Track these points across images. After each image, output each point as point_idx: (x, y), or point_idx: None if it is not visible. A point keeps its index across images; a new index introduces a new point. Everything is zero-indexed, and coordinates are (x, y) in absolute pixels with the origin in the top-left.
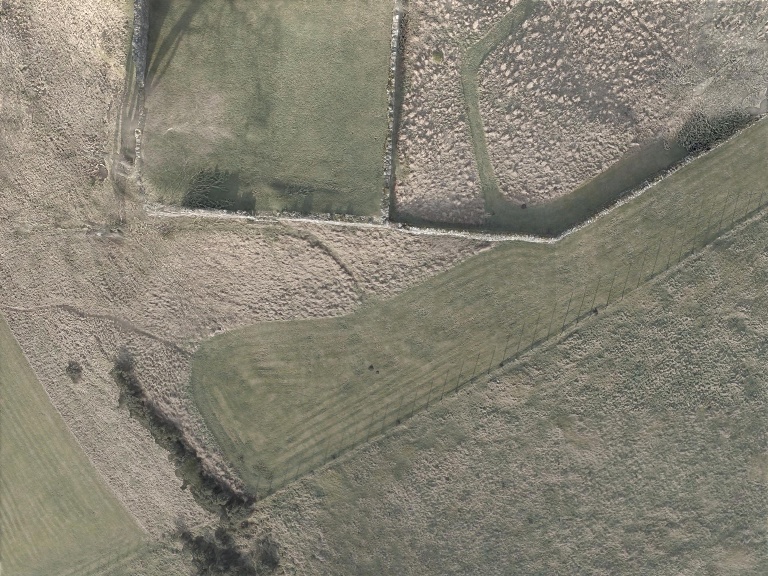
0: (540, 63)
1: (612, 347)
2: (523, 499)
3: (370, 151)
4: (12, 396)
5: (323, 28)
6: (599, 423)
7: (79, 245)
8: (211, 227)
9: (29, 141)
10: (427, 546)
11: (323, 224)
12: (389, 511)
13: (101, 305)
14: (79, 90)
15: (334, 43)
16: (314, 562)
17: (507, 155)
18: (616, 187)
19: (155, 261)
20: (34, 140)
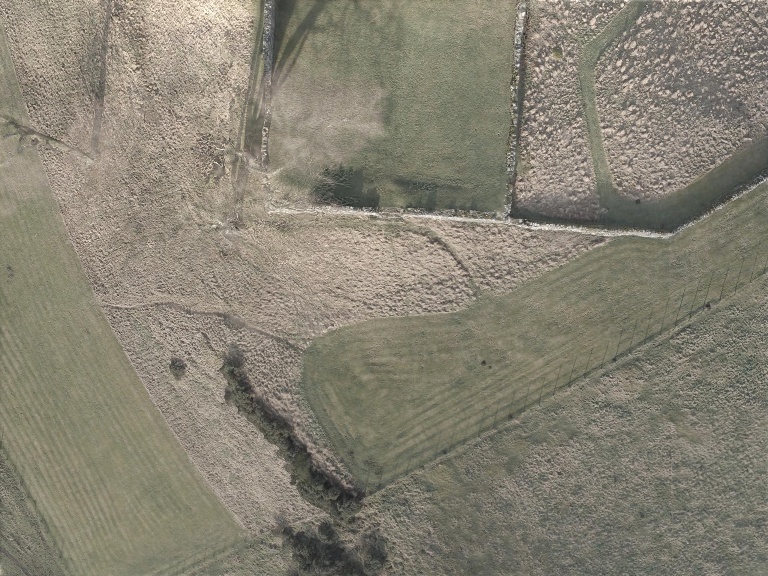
0: (654, 59)
1: (724, 342)
2: (635, 493)
3: (493, 147)
4: (111, 393)
5: (446, 26)
6: (711, 417)
7: (189, 243)
8: (332, 224)
9: (140, 140)
10: (539, 540)
11: (444, 220)
12: (500, 506)
13: (210, 302)
14: (195, 89)
15: (457, 40)
16: (424, 556)
17: (622, 151)
18: (729, 182)
19: (271, 258)
20: (146, 139)
